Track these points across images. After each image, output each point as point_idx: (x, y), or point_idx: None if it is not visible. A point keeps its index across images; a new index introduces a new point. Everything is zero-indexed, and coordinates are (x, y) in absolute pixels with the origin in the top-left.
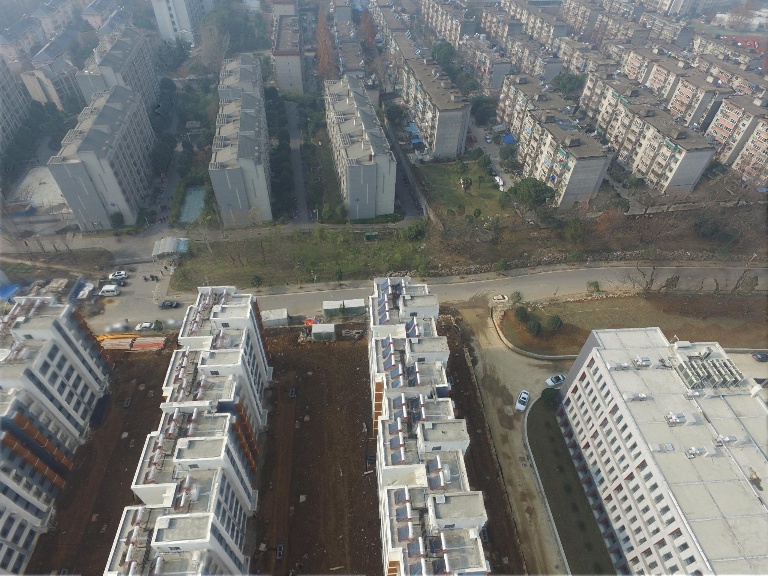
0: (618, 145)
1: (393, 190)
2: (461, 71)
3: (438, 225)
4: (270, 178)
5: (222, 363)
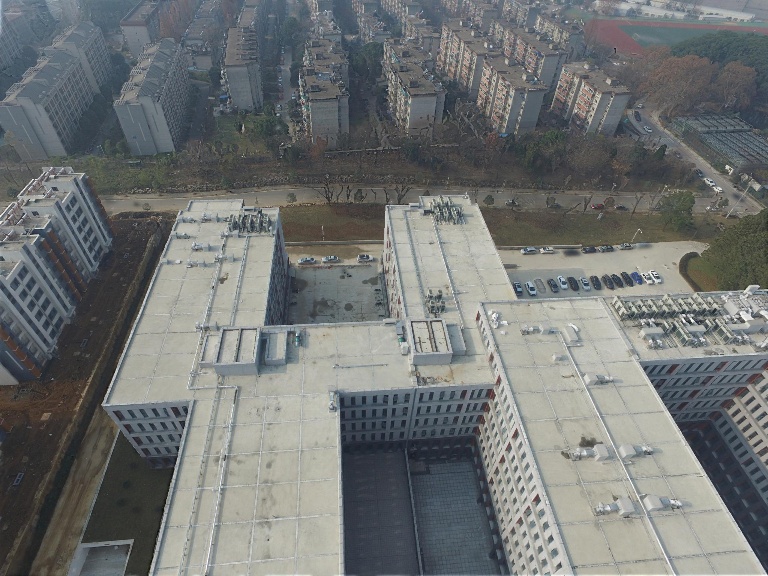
0: (389, 98)
1: (166, 129)
2: (300, 42)
3: (196, 156)
4: (78, 124)
5: None
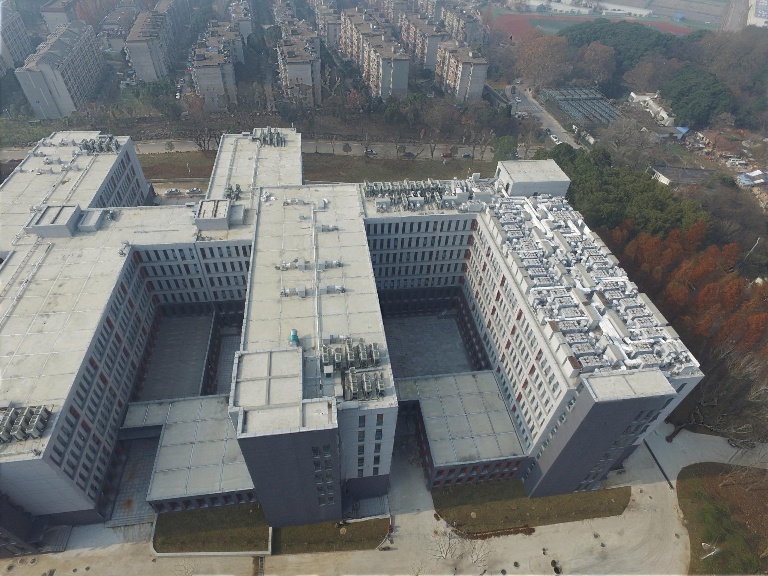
0: None
1: (67, 95)
2: None
3: None
4: None
5: None
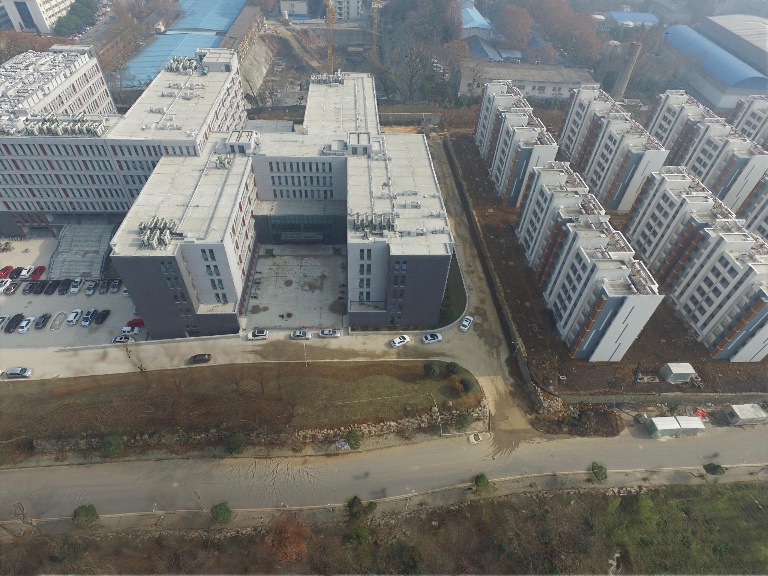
0: None
1: None
2: None
3: None
4: None
5: (733, 236)
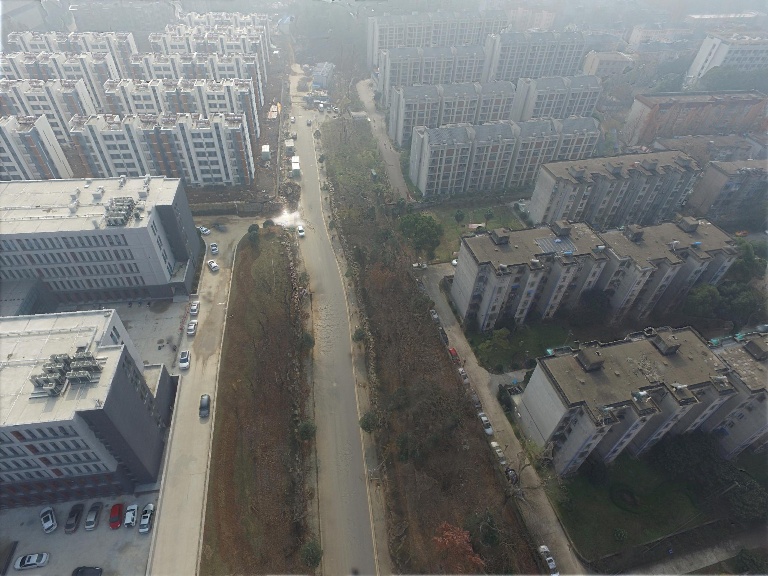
0: None
1: (426, 172)
2: None
3: None
4: None
5: (197, 83)
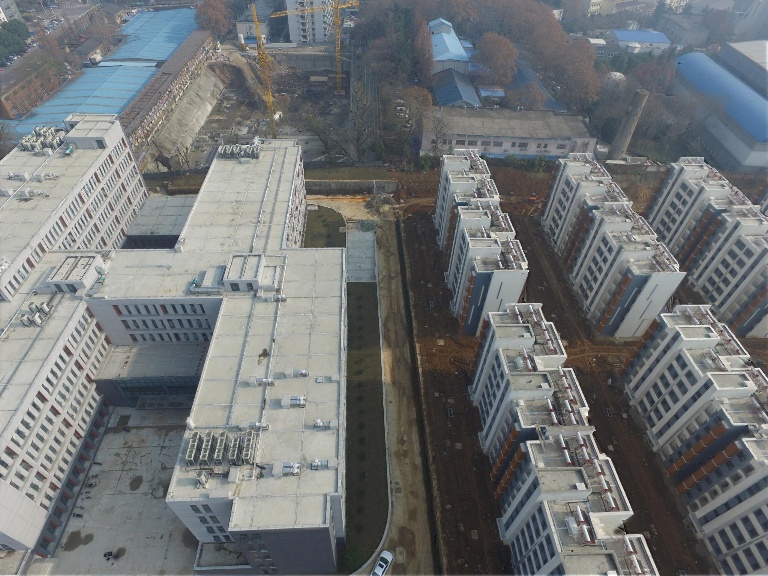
0: None
1: None
2: None
3: None
4: None
5: None
